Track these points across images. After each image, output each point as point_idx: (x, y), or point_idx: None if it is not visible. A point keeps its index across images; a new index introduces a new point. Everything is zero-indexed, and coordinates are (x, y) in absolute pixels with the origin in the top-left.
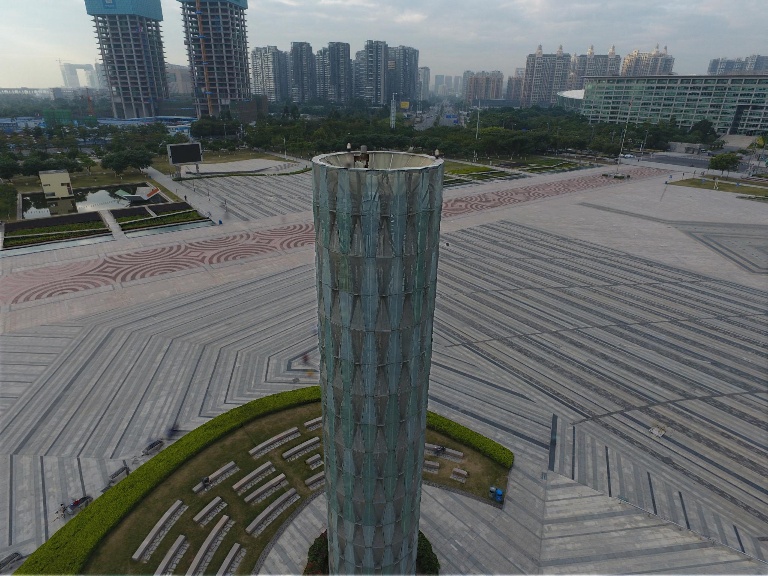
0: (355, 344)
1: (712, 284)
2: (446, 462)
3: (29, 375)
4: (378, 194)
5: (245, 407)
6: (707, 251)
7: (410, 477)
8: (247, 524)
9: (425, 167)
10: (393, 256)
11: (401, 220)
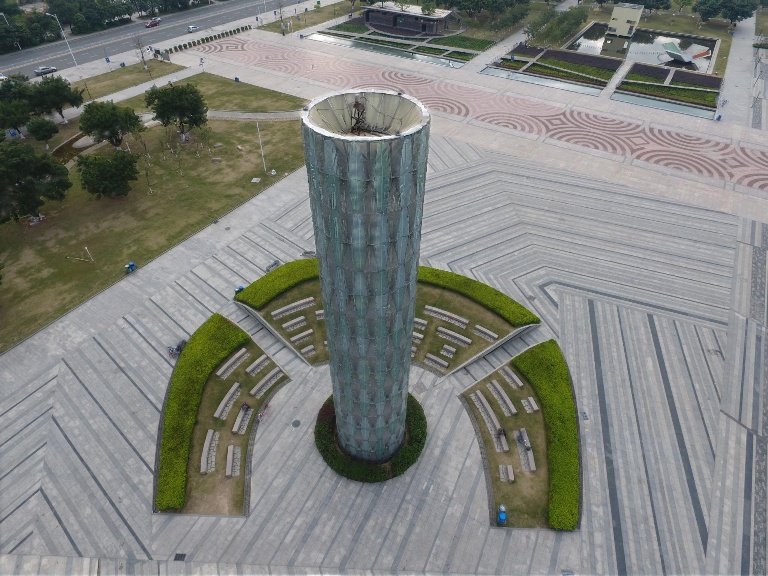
0: None
1: None
2: (516, 456)
3: None
4: (305, 141)
5: (469, 281)
6: None
7: (350, 376)
8: None
9: (330, 136)
10: None
11: None
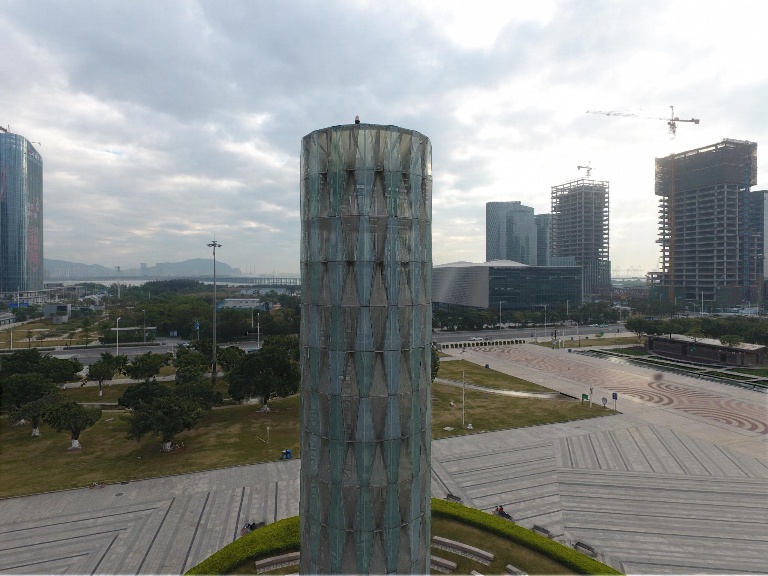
0: None
1: None
2: None
3: (664, 469)
4: None
5: None
6: None
7: None
8: None
9: None
10: None
11: None
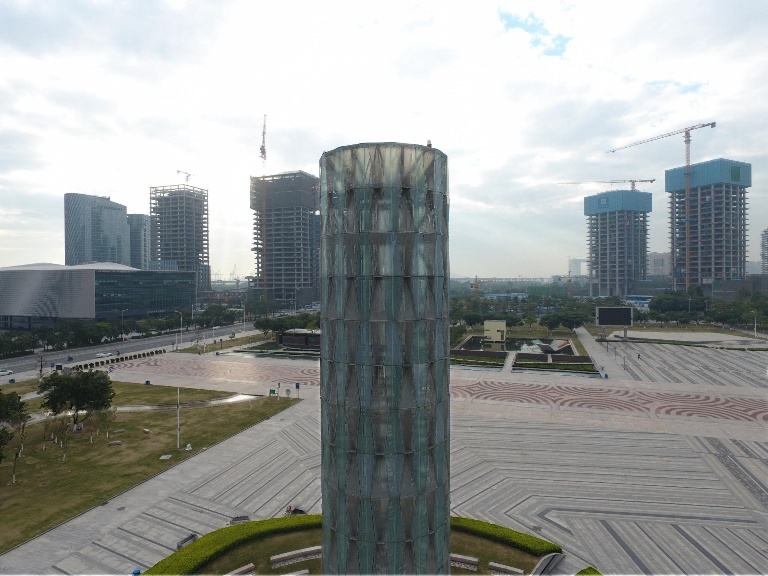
0: None
1: None
2: None
3: None
4: (326, 173)
5: (457, 518)
6: None
7: (371, 560)
8: None
9: None
10: (336, 233)
11: (342, 196)
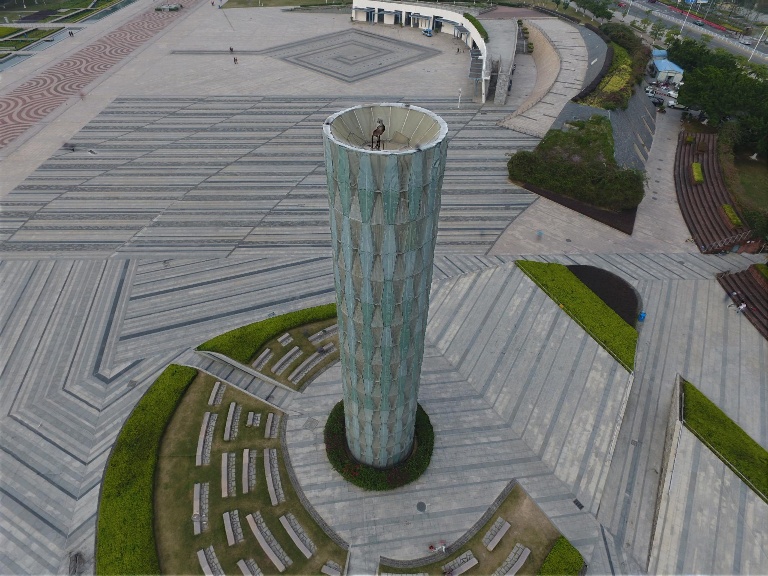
0: (414, 285)
1: (338, 103)
2: (333, 338)
3: None
4: None
5: (125, 445)
6: (310, 73)
7: None
8: (268, 502)
9: None
10: None
11: None
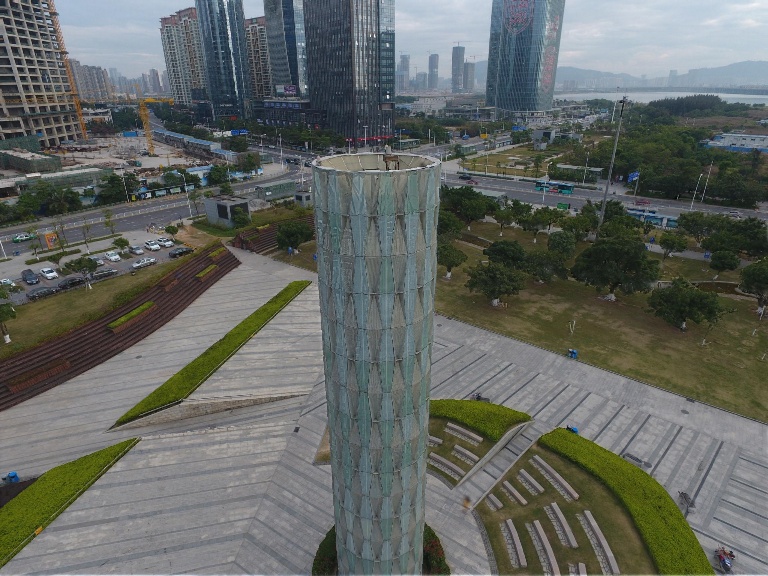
0: None
1: None
2: None
3: None
4: None
5: None
6: None
7: None
8: None
9: None
10: None
11: None
